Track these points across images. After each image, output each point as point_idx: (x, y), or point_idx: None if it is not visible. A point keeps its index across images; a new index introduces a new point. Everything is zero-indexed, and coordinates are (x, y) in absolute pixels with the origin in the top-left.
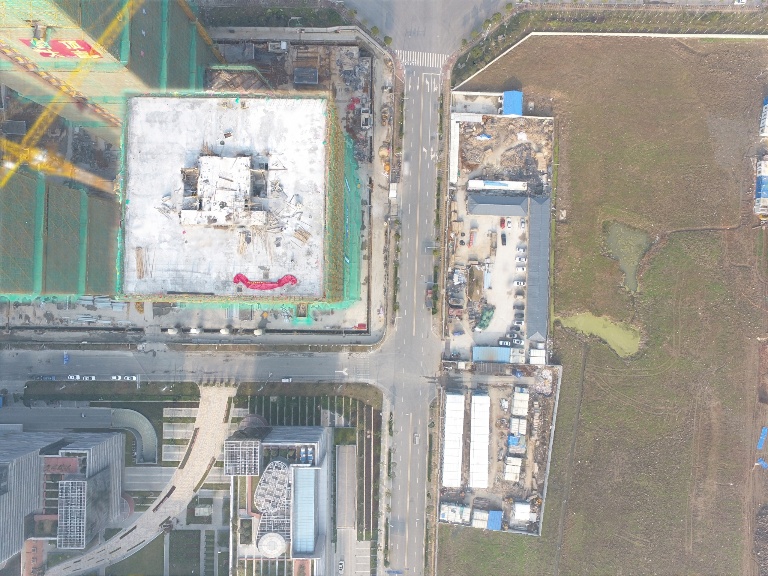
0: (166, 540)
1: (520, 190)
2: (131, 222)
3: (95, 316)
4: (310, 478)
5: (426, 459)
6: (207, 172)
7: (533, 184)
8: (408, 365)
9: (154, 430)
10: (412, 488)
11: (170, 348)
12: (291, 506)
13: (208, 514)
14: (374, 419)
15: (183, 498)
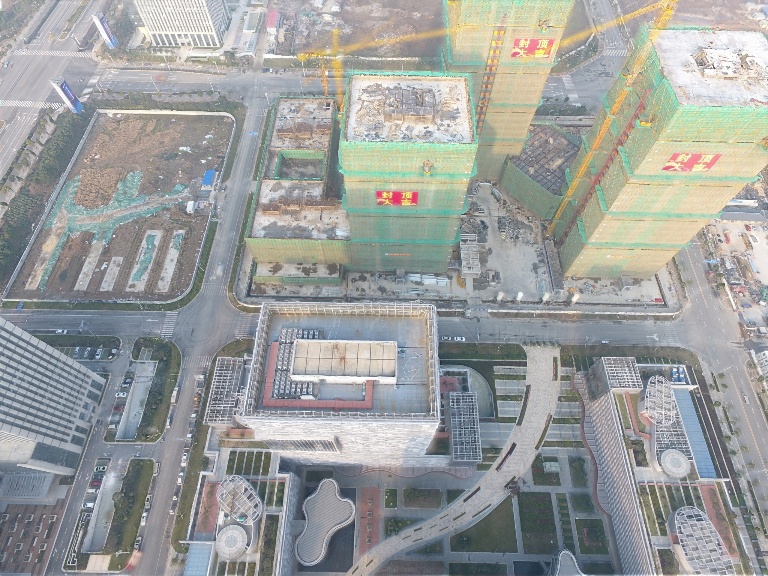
0: (514, 504)
1: (751, 207)
2: (670, 76)
3: (422, 290)
4: (687, 399)
5: (763, 418)
6: (711, 54)
7: (759, 204)
8: (712, 332)
9: (489, 385)
10: (761, 448)
11: (492, 315)
12: (681, 422)
13: (560, 469)
14: (698, 379)
15: (526, 456)
